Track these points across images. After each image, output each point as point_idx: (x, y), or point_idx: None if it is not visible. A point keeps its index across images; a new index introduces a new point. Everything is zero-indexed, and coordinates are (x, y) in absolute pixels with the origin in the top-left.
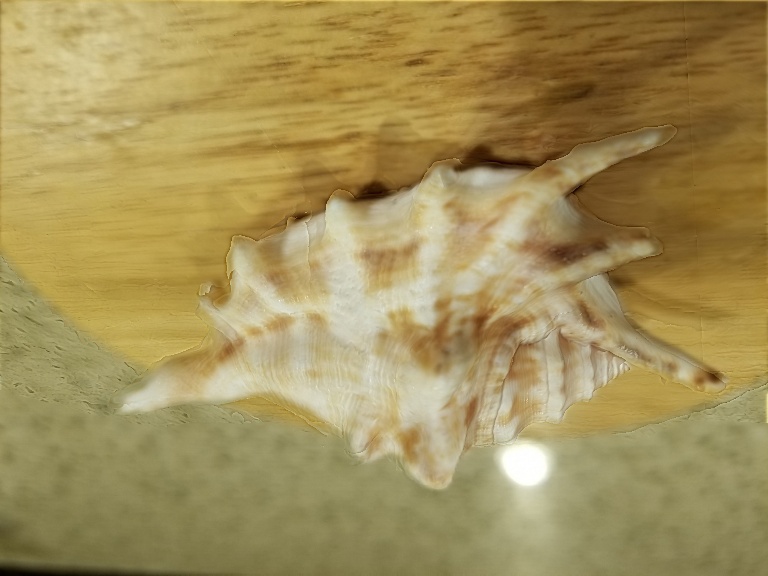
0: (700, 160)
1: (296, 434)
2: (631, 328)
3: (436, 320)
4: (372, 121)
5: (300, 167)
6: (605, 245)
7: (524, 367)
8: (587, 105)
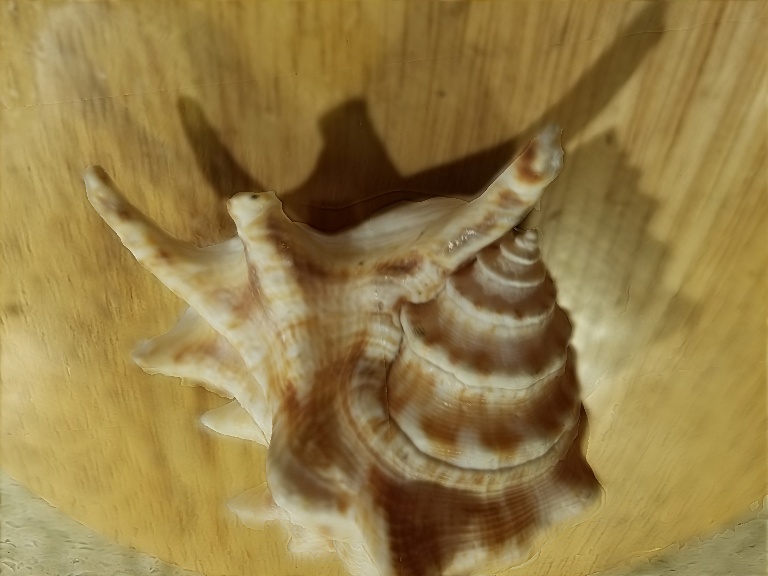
0: (252, 72)
1: (710, 532)
2: (450, 214)
3: None
4: None
5: None
6: (244, 248)
7: (408, 380)
8: (165, 189)
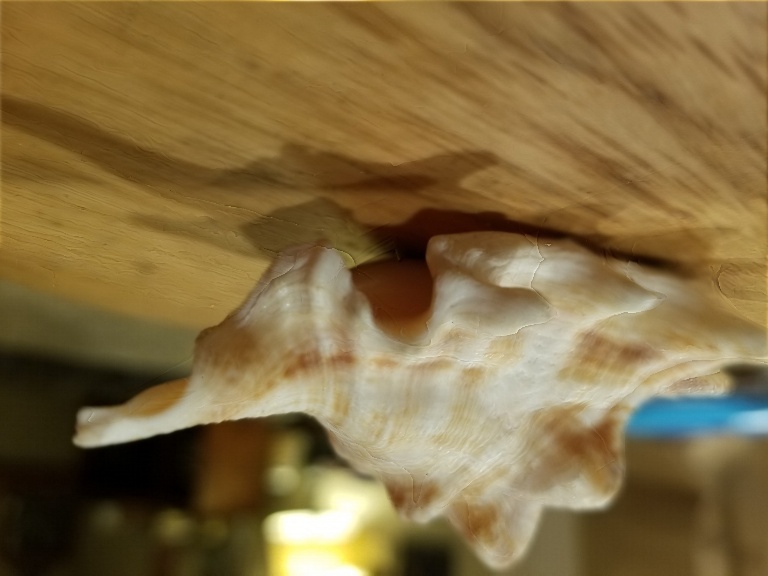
0: (749, 314)
1: (27, 268)
2: None
3: (600, 421)
4: (722, 223)
5: (601, 201)
6: None
7: None
8: None
